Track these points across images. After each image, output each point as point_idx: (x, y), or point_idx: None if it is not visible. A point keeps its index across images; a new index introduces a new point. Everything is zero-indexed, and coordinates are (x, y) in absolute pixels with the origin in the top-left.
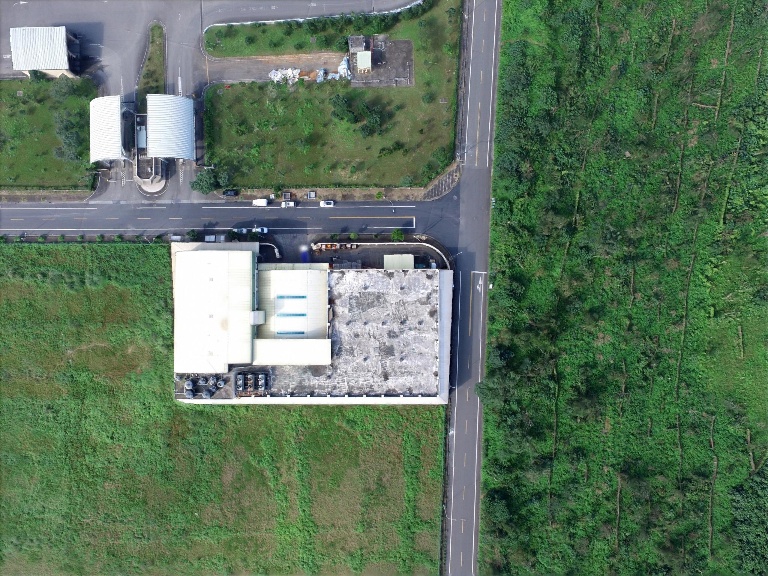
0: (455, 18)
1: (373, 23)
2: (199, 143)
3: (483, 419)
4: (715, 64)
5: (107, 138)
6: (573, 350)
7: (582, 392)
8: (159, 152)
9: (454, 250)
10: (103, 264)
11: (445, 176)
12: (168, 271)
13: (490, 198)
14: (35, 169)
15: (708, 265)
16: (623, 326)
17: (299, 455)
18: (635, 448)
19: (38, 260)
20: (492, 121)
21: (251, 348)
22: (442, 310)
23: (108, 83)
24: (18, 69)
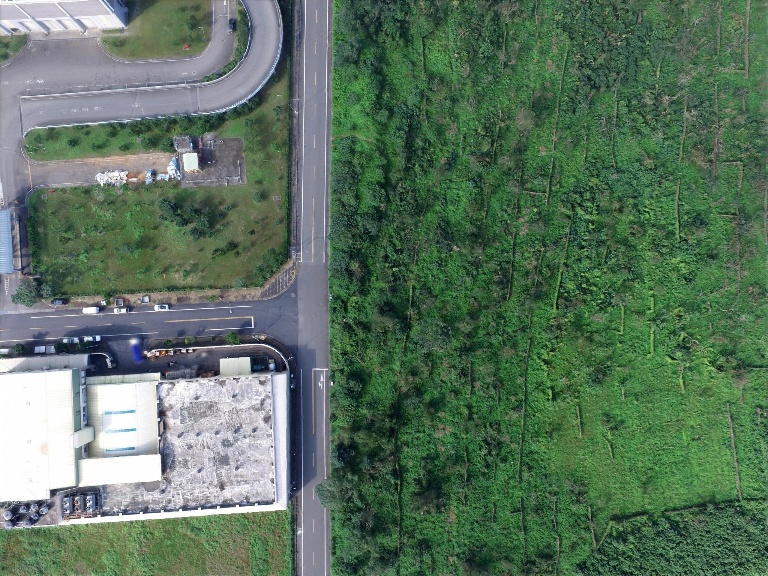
0: (285, 114)
1: (199, 124)
2: (24, 251)
3: (330, 517)
4: (543, 151)
5: None
6: (415, 443)
7: (423, 485)
8: None
9: (294, 348)
10: None
11: (282, 274)
12: None
13: (328, 294)
14: None
15: (544, 350)
16: (463, 415)
17: (143, 568)
18: (480, 535)
19: None
20: (327, 216)
21: (75, 470)
22: (277, 415)
23: None
24: None
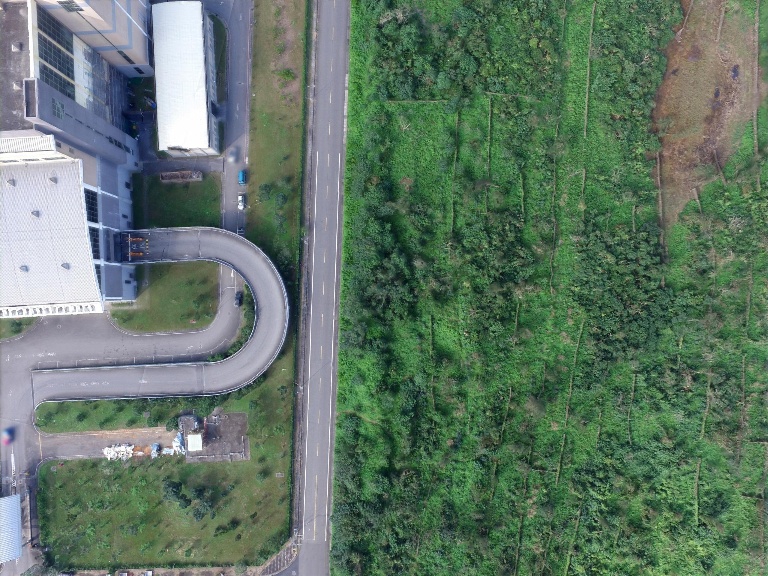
0: (290, 389)
1: None
2: (34, 522)
3: None
4: (555, 427)
5: None
6: None
7: None
8: None
9: None
10: None
11: (283, 552)
12: None
13: (329, 573)
14: None
15: None
16: None
17: None
18: None
19: None
20: (330, 494)
21: None
22: None
23: None
24: None
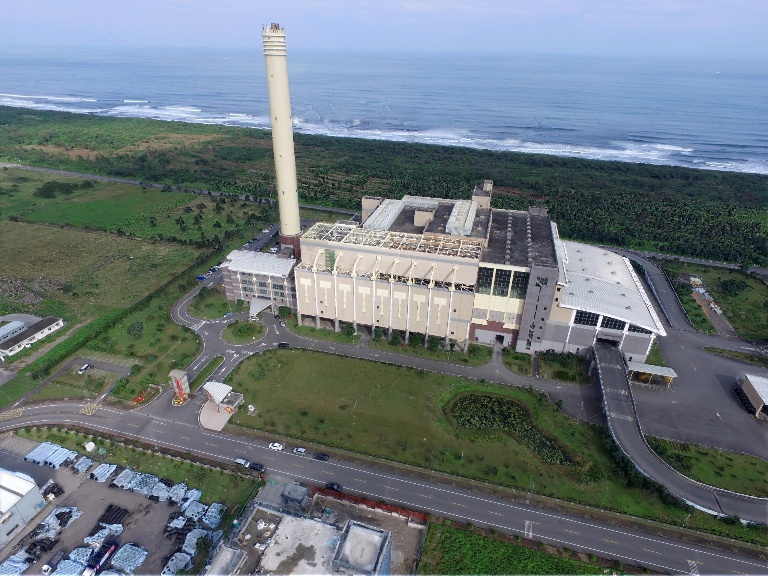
0: None
1: None
2: None
3: None
4: None
5: None
6: None
7: None
8: None
9: None
10: None
11: None
12: None
13: None
14: None
15: None
16: None
17: None
18: None
19: None
20: None
21: None
22: None
23: None
24: None
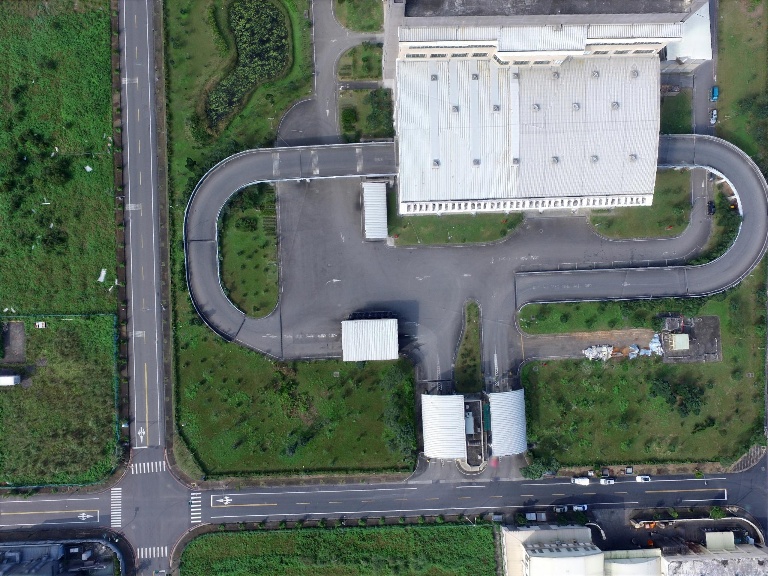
0: None
1: (688, 305)
2: None
3: None
4: None
5: (451, 438)
6: None
7: None
8: (503, 451)
9: (764, 520)
10: (427, 547)
11: (753, 448)
12: (492, 552)
13: None
14: (354, 451)
15: None
16: None
17: None
18: None
19: (360, 544)
20: None
21: None
22: None
23: (425, 362)
24: (348, 360)
